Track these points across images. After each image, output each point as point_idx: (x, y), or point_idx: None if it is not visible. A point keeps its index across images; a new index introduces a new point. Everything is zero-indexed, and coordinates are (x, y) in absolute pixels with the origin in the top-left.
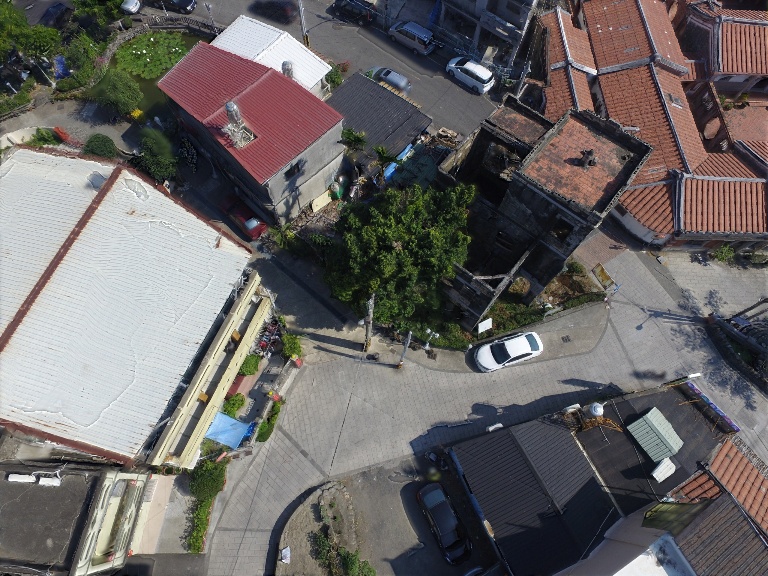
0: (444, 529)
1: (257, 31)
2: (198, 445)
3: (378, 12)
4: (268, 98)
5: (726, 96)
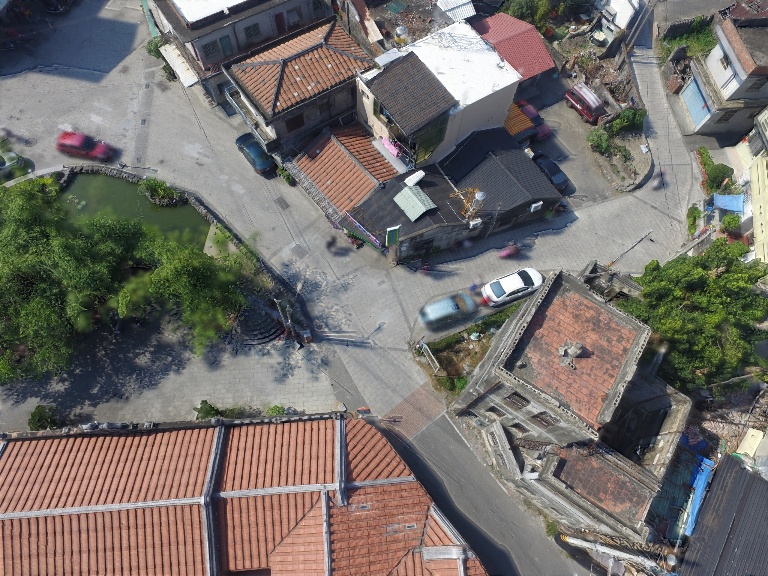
0: (550, 162)
1: None
2: None
3: None
4: None
5: None
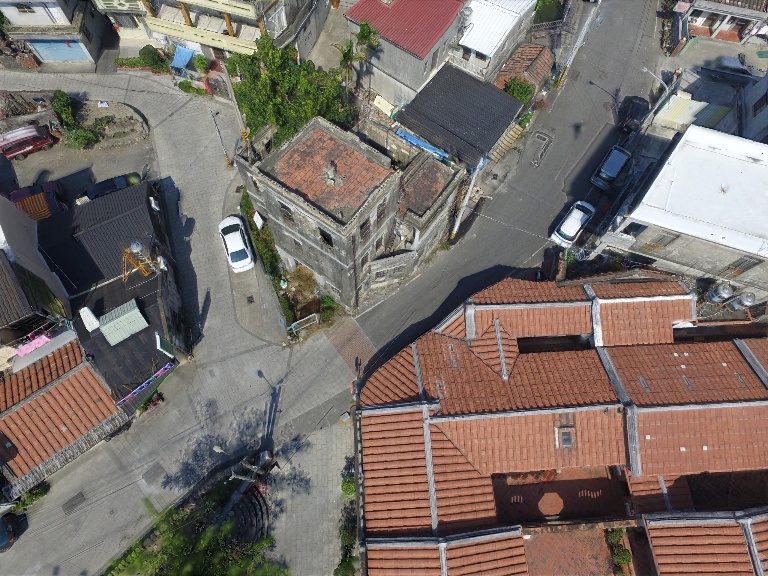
0: (97, 187)
1: (521, 2)
2: (163, 32)
3: (644, 138)
4: (431, 6)
5: (642, 575)
